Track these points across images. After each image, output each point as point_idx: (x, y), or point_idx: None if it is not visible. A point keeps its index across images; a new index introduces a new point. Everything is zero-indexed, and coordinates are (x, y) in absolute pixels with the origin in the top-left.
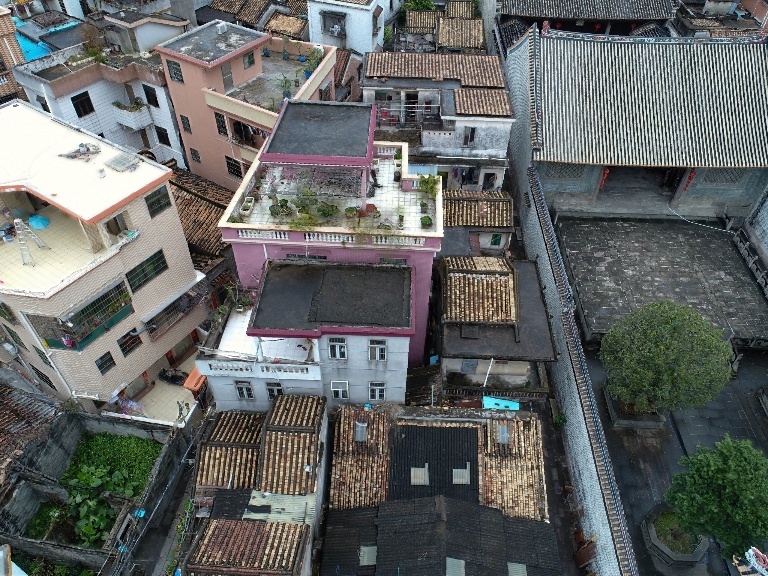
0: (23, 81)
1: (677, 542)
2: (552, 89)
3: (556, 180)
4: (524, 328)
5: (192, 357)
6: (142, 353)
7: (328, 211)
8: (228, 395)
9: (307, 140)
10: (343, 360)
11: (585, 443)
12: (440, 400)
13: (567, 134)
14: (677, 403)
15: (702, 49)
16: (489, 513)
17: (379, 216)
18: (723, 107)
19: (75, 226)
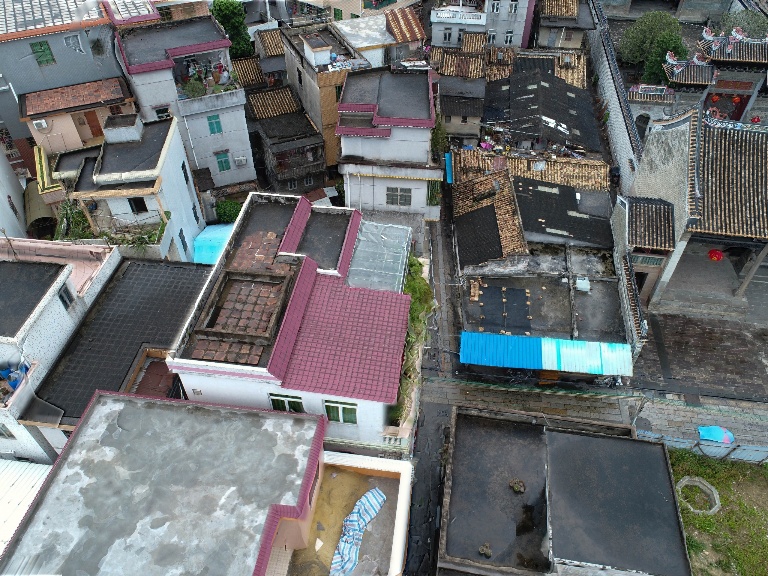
0: None
1: None
2: None
3: None
4: (581, 20)
5: None
6: None
7: None
8: (439, 39)
9: None
10: (497, 14)
11: None
12: None
13: None
14: None
15: None
16: (559, 79)
17: None
18: None
19: None
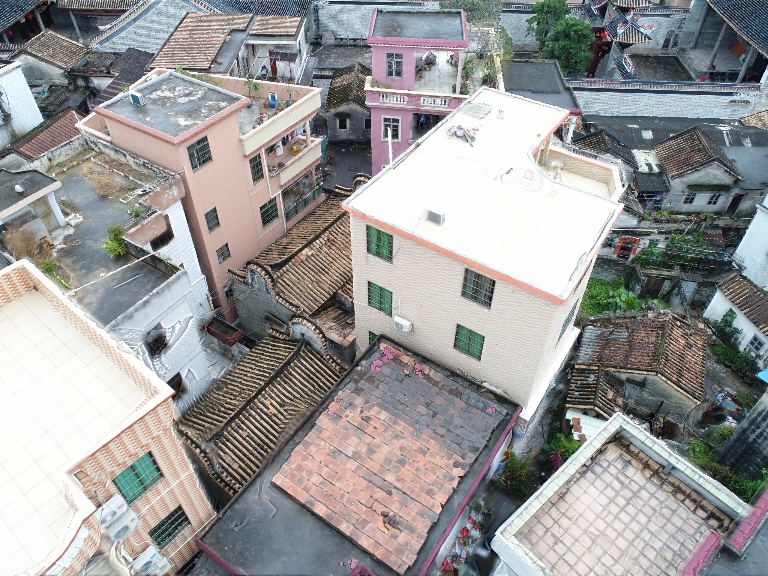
0: None
1: None
2: None
3: None
4: None
5: None
6: None
7: None
8: None
9: (435, 32)
10: None
11: None
12: None
13: None
14: None
15: None
16: None
17: None
18: None
19: None
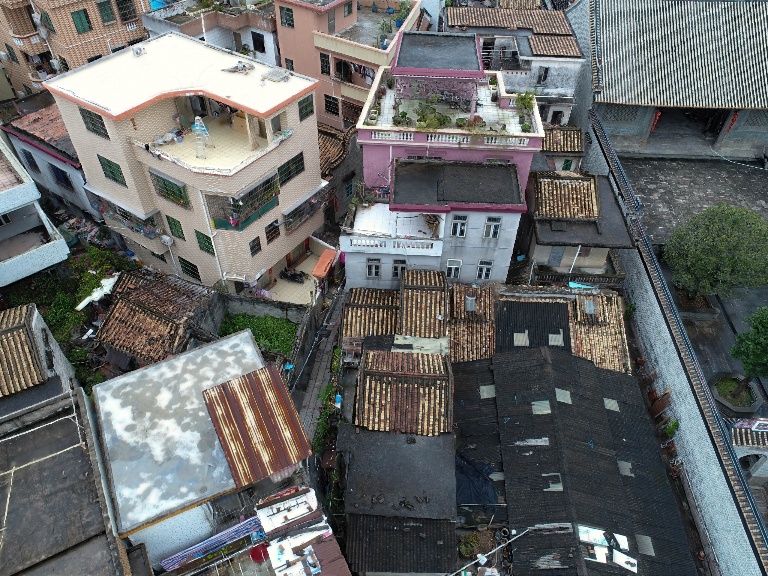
0: (152, 26)
1: (736, 400)
2: (610, 40)
3: (611, 123)
4: (604, 224)
5: (304, 262)
6: (278, 244)
7: (443, 120)
8: (358, 273)
9: (427, 60)
10: (461, 238)
11: (657, 318)
12: (532, 284)
13: (624, 79)
14: (729, 301)
15: (745, 6)
16: (584, 363)
17: (485, 126)
18: (764, 56)
19: (230, 132)
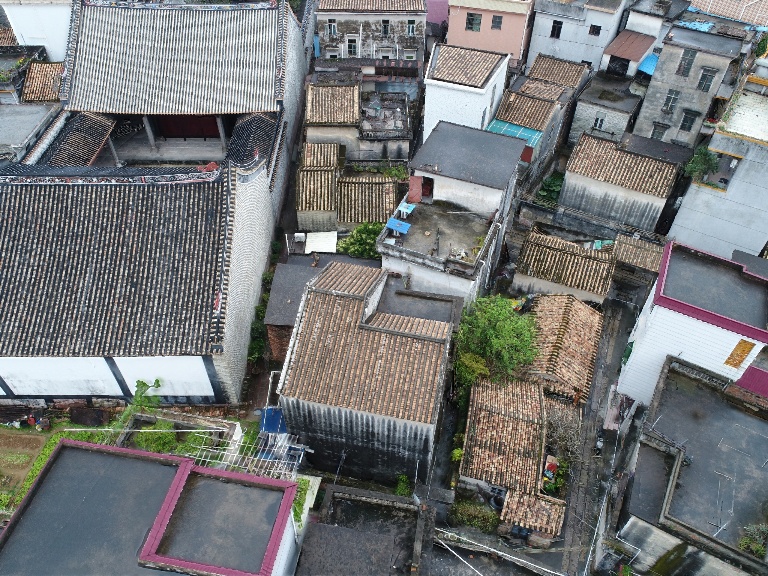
0: None
1: None
2: None
3: None
4: None
5: None
6: None
7: None
8: None
9: None
10: None
11: None
12: None
13: None
14: None
15: None
16: None
17: None
18: None
19: None
